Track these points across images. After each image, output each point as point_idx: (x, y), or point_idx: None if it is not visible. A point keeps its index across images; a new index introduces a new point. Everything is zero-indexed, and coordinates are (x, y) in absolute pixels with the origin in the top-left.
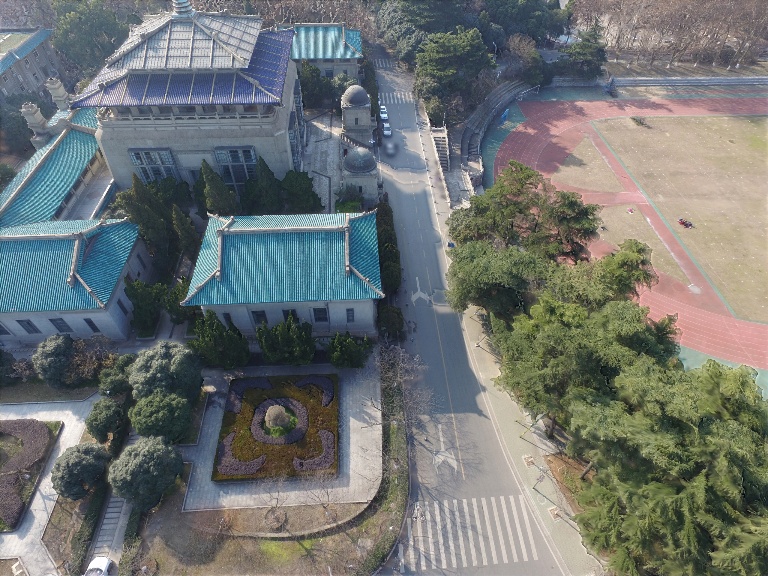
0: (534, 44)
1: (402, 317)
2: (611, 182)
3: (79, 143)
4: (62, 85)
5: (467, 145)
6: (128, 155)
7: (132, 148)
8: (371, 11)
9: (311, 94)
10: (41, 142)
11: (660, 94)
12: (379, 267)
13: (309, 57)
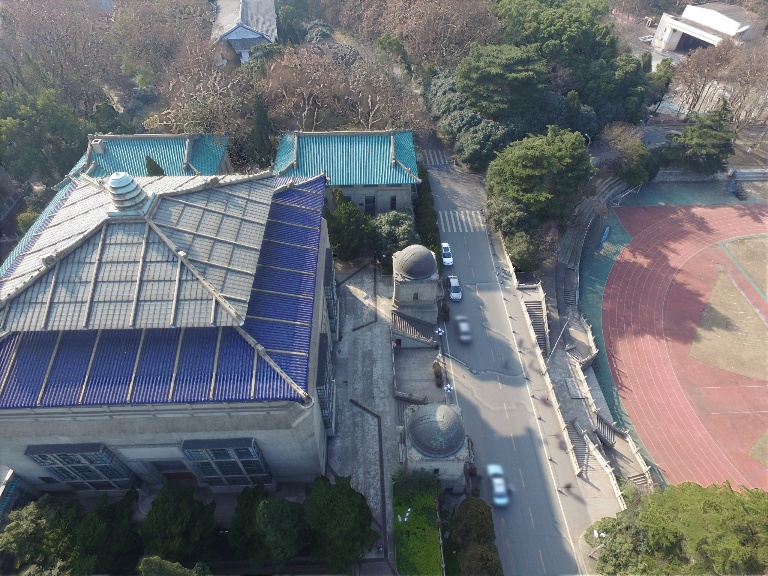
0: (641, 136)
1: None
2: None
3: None
4: None
5: (562, 295)
6: None
7: (34, 445)
8: (417, 83)
9: (346, 246)
10: None
11: None
12: None
13: (343, 183)
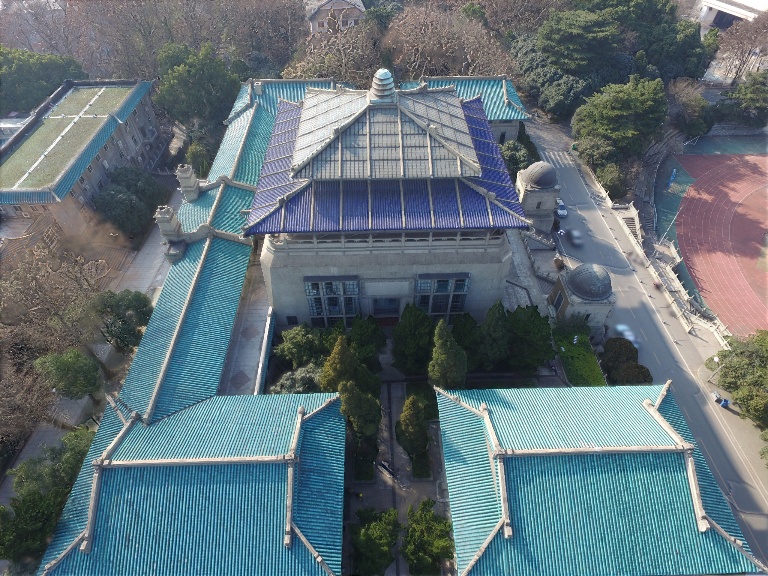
0: (703, 90)
1: None
2: None
3: (226, 257)
4: None
5: (644, 220)
6: (300, 283)
7: (309, 276)
8: None
9: None
10: (177, 255)
11: None
12: None
13: None
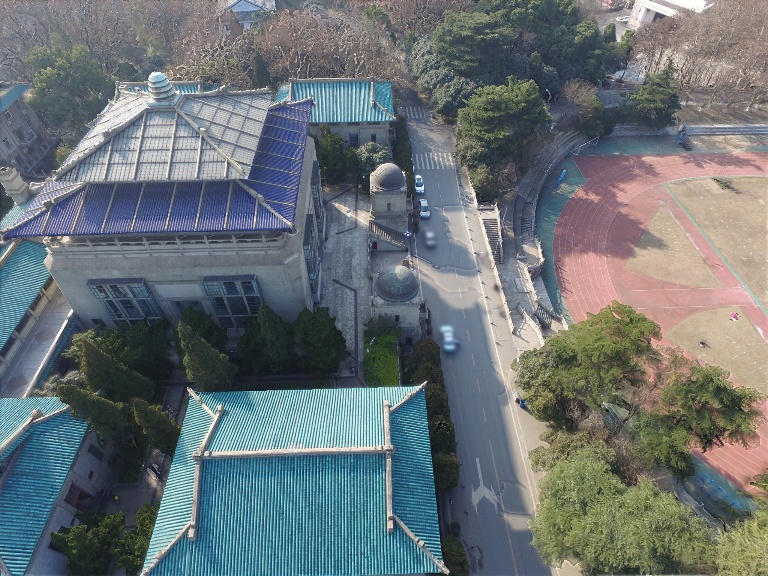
0: (595, 91)
1: (467, 566)
2: (703, 272)
3: (31, 260)
4: (18, 175)
5: (520, 221)
6: None
7: (93, 279)
8: (401, 50)
9: (332, 169)
10: None
11: (743, 146)
12: (435, 501)
13: (330, 120)
